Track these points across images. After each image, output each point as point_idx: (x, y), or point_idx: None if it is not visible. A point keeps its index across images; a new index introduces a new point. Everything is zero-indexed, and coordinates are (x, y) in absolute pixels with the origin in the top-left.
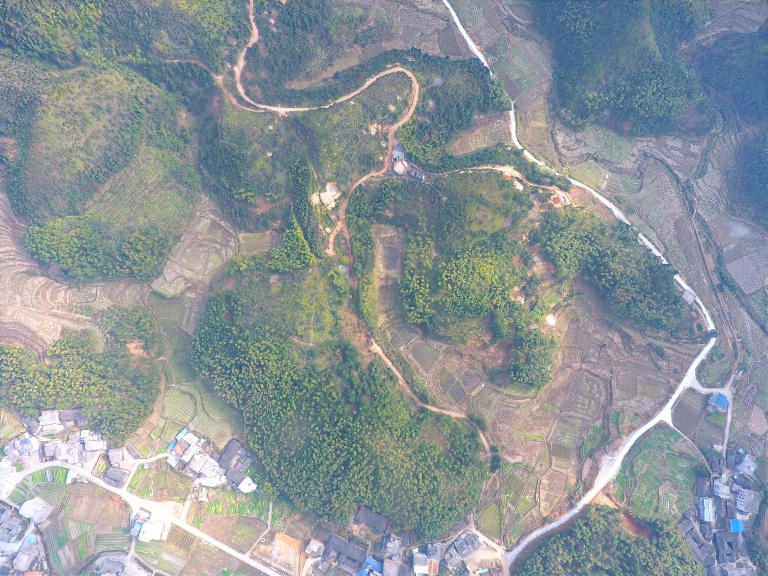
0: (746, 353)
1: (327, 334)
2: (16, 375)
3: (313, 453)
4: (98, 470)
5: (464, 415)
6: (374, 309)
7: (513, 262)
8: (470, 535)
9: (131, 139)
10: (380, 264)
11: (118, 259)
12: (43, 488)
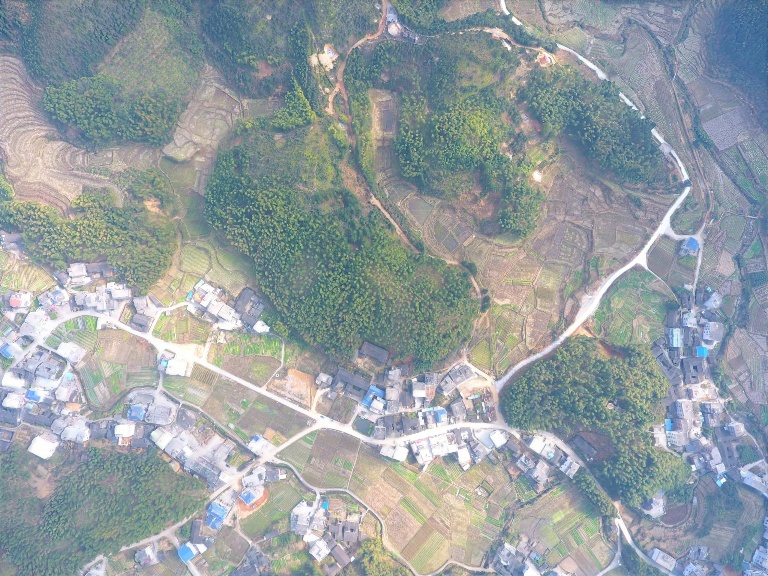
0: (718, 204)
1: (329, 184)
2: (44, 229)
3: (320, 288)
4: (125, 318)
5: (457, 262)
6: (372, 168)
7: (501, 119)
8: (463, 366)
9: (136, 3)
10: (377, 126)
11: (131, 121)
12: (76, 334)
